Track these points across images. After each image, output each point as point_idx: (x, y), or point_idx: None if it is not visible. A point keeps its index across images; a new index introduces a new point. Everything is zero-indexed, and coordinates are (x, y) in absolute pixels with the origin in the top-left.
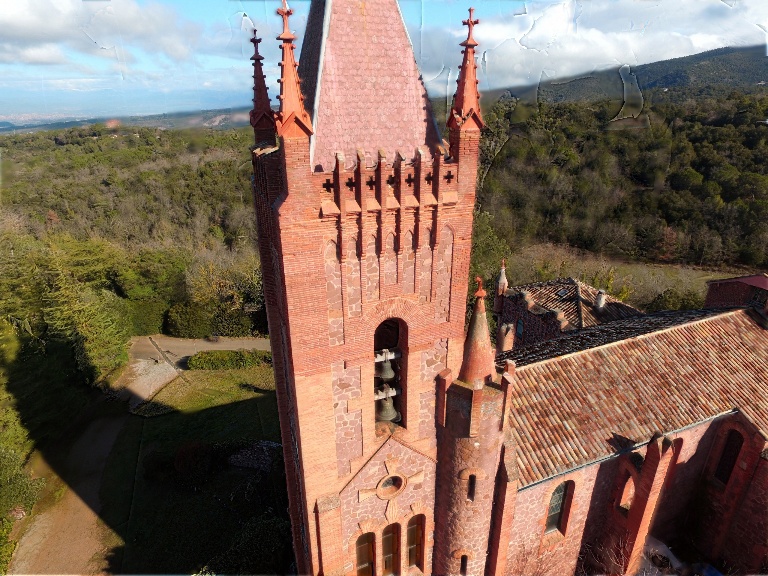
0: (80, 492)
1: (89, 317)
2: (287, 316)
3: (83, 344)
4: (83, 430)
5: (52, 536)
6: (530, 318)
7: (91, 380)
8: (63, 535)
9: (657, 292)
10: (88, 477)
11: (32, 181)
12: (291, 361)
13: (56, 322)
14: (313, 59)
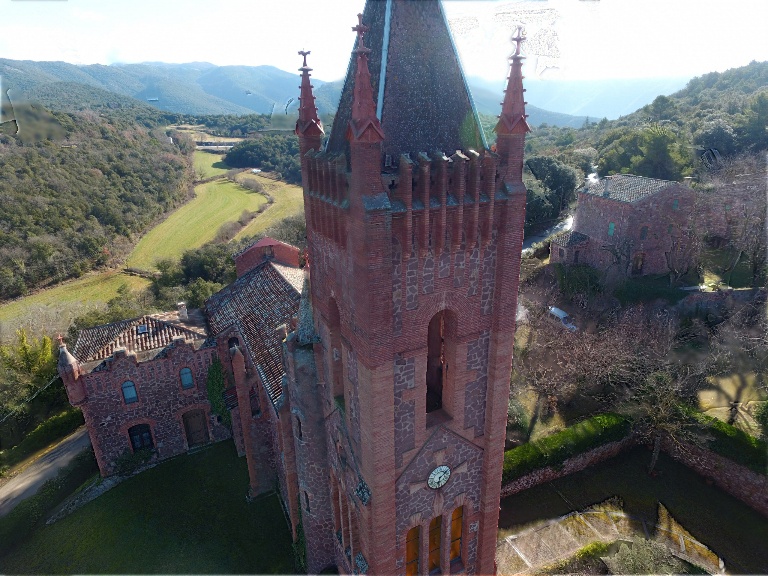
0: None
1: None
2: (515, 282)
3: None
4: None
5: None
6: (142, 370)
7: None
8: None
9: (51, 332)
10: None
11: None
12: (510, 324)
13: None
14: (443, 70)
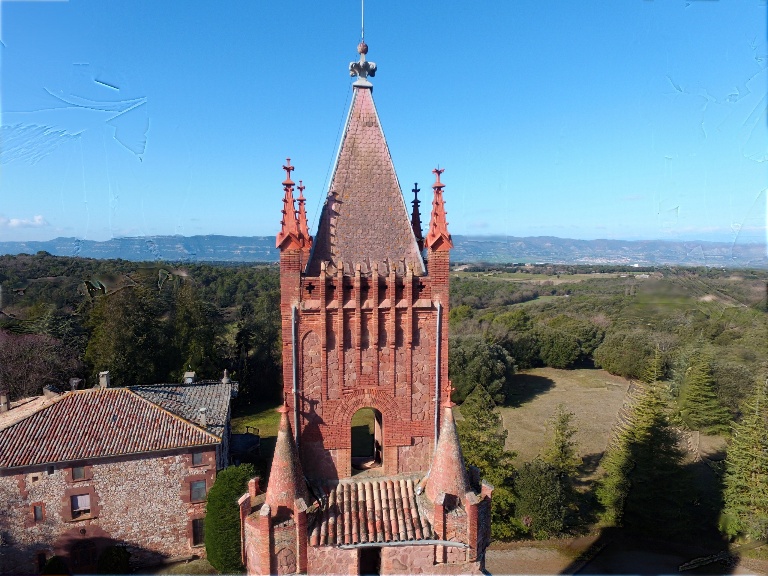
0: (584, 569)
1: (763, 471)
2: None
3: (743, 492)
4: (663, 552)
5: (537, 563)
6: None
7: (724, 530)
8: (539, 569)
9: None
10: (603, 570)
11: (708, 307)
12: None
13: (729, 454)
14: None
